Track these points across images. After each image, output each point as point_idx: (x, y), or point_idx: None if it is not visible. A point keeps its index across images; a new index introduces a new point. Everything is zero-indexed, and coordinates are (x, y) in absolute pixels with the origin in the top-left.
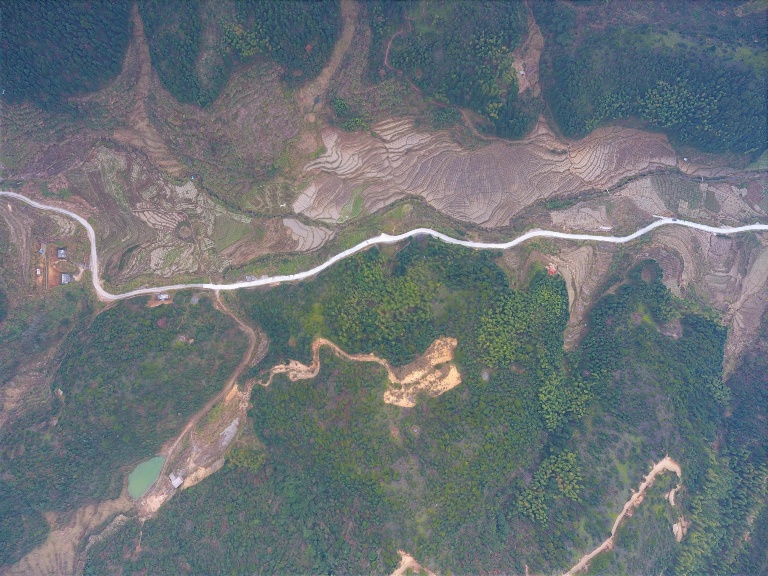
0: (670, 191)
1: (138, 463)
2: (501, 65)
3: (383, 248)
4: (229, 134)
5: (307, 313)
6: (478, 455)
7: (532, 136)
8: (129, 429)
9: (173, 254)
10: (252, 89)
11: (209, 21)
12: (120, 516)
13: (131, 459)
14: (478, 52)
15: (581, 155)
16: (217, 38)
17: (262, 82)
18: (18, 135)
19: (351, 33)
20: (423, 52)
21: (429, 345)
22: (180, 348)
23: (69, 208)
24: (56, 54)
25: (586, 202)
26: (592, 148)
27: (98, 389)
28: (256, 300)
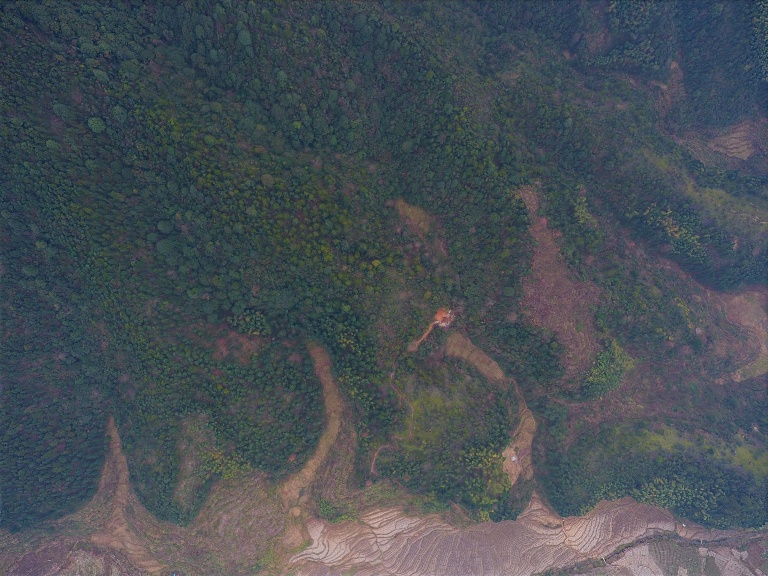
0: (668, 559)
1: None
2: (492, 474)
3: None
4: (211, 545)
5: None
6: None
7: (525, 512)
8: None
9: None
10: (234, 497)
11: None
12: None
13: None
14: (468, 464)
15: (576, 527)
16: (196, 461)
17: (244, 488)
18: None
19: (336, 428)
20: (411, 468)
21: None
22: None
23: None
24: None
25: (582, 575)
26: (587, 519)
27: None
28: None
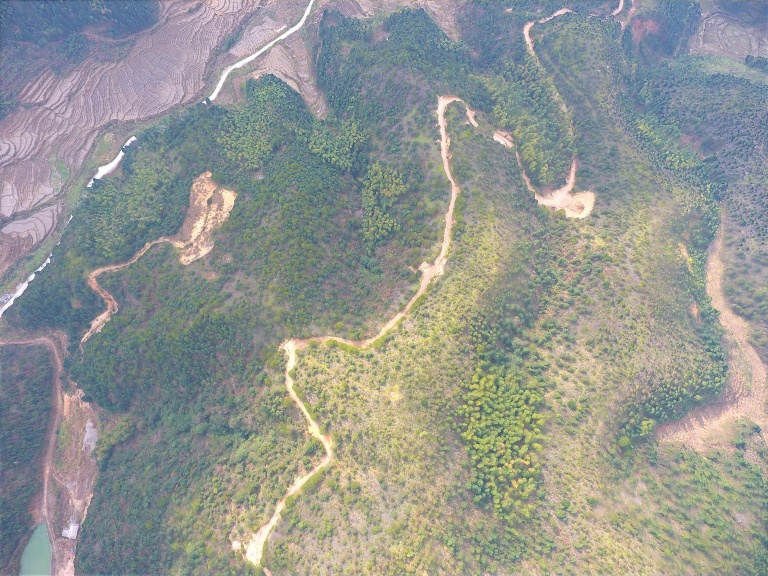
0: None
1: (18, 554)
2: None
3: None
4: None
5: (62, 265)
6: (283, 218)
7: (163, 13)
8: None
9: None
10: None
11: None
12: None
13: (2, 554)
14: None
15: None
16: None
17: None
18: None
19: None
20: None
21: (188, 194)
22: None
23: None
24: None
25: (250, 24)
26: None
27: None
28: (18, 305)
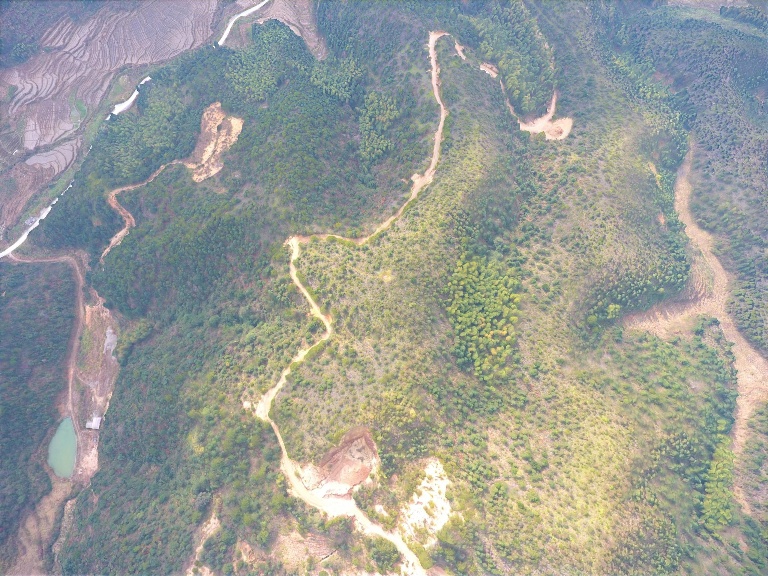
0: None
1: (46, 443)
2: None
3: None
4: None
5: (84, 186)
6: (287, 135)
7: None
8: None
9: None
10: None
11: None
12: (68, 504)
13: (32, 441)
14: None
15: None
16: None
17: None
18: None
19: None
20: None
21: (199, 121)
22: None
23: None
24: None
25: None
26: None
27: None
28: (43, 225)
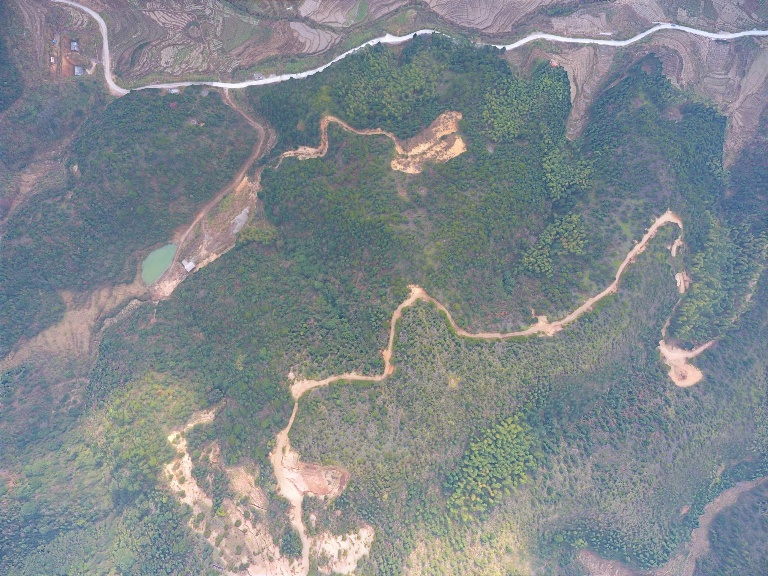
0: None
1: (151, 249)
2: None
3: (388, 48)
4: None
5: (315, 93)
6: (484, 201)
7: None
8: (143, 201)
9: (183, 53)
10: None
11: None
12: (134, 301)
13: (144, 242)
14: None
15: None
16: None
17: None
18: None
19: None
20: None
21: (435, 118)
22: (191, 127)
23: (81, 1)
24: None
25: (586, 9)
26: None
27: (113, 152)
28: (265, 91)
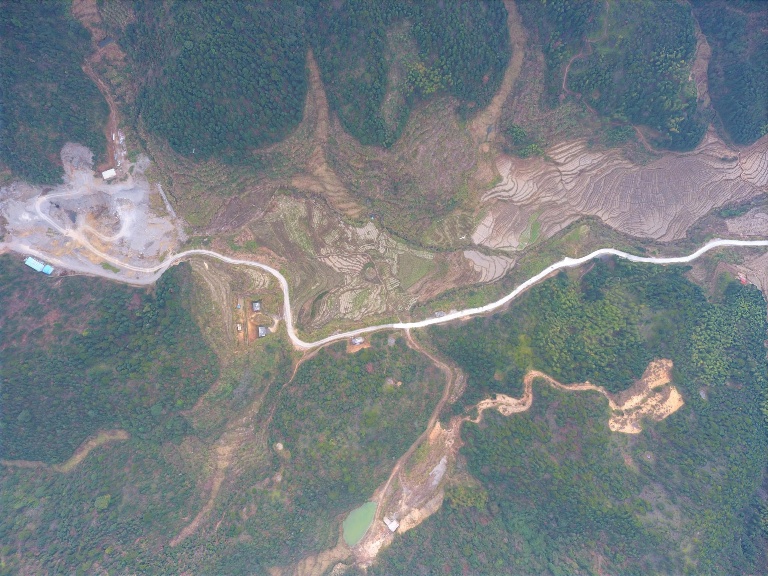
0: None
1: (351, 510)
2: (681, 79)
3: (568, 272)
4: (412, 172)
5: (515, 346)
6: (727, 478)
7: (702, 146)
8: (354, 478)
9: (361, 297)
10: (430, 125)
11: (393, 62)
12: (339, 564)
13: (347, 507)
14: (658, 68)
15: (751, 160)
16: (398, 78)
17: (439, 117)
18: (202, 192)
19: (520, 59)
20: (604, 73)
21: (645, 368)
22: (392, 392)
23: (261, 260)
24: (247, 109)
25: (760, 207)
26: (761, 152)
27: (329, 442)
28: (453, 336)
